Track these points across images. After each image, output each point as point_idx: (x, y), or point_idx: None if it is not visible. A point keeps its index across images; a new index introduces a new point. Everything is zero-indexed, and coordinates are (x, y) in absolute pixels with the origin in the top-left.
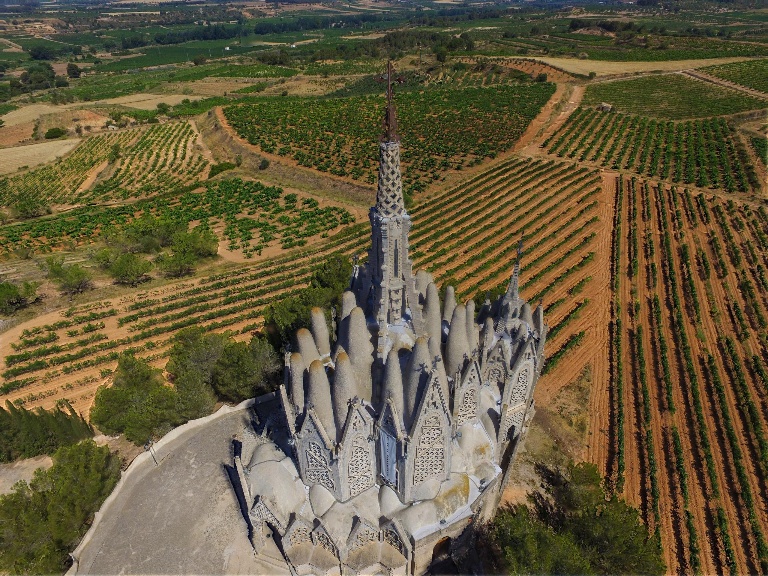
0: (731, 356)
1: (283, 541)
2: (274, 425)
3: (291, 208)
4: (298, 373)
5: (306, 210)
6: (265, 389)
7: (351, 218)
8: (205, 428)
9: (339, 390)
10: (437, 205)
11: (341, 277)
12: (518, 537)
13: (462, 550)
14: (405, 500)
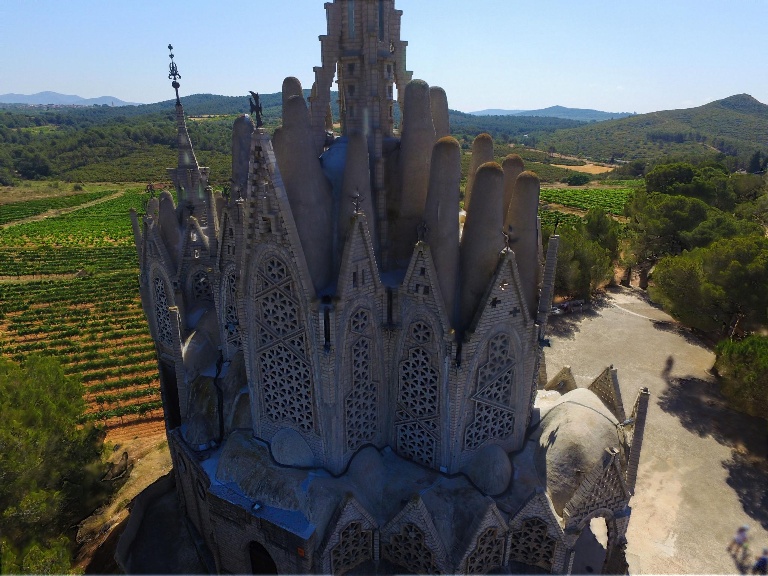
0: None
1: None
2: None
3: None
4: None
5: None
6: None
7: None
8: None
9: None
10: None
11: None
12: None
13: None
14: None
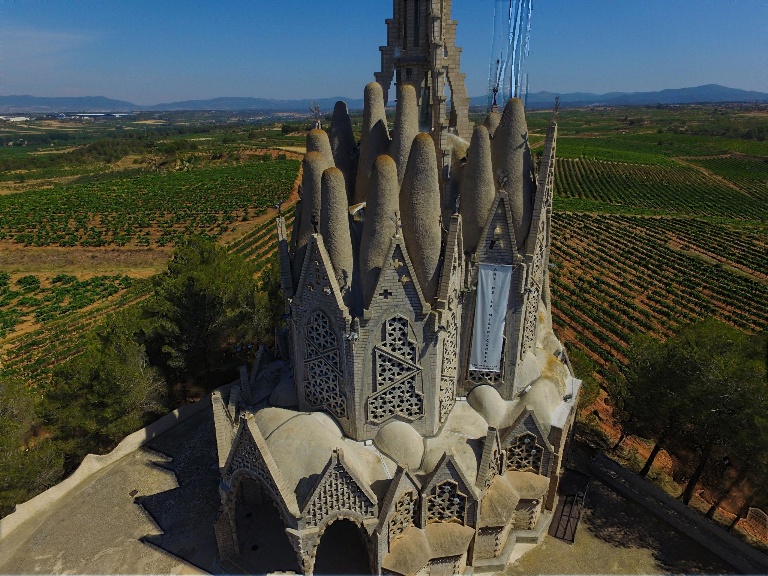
0: (562, 288)
1: (381, 538)
2: (242, 401)
3: (33, 290)
4: (342, 201)
5: (60, 287)
6: (156, 413)
7: (135, 280)
8: (58, 509)
9: (425, 201)
10: (243, 245)
11: (207, 262)
12: (676, 346)
13: (568, 456)
14: (513, 392)
